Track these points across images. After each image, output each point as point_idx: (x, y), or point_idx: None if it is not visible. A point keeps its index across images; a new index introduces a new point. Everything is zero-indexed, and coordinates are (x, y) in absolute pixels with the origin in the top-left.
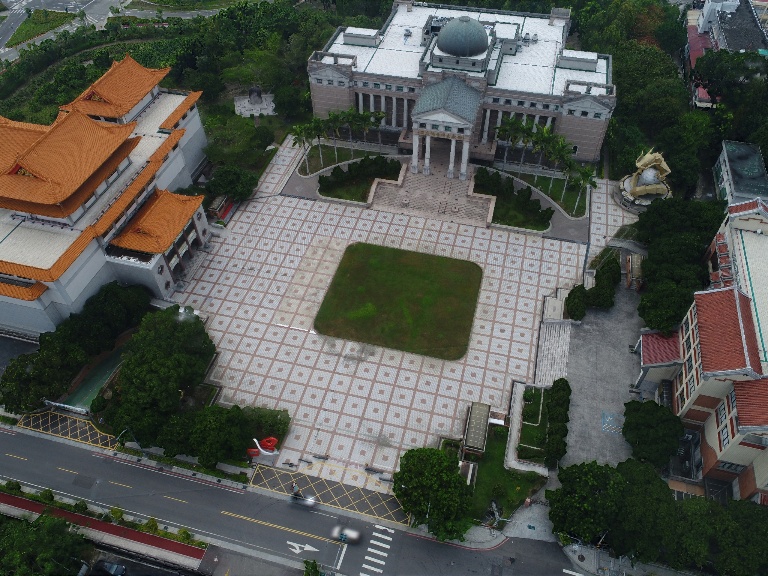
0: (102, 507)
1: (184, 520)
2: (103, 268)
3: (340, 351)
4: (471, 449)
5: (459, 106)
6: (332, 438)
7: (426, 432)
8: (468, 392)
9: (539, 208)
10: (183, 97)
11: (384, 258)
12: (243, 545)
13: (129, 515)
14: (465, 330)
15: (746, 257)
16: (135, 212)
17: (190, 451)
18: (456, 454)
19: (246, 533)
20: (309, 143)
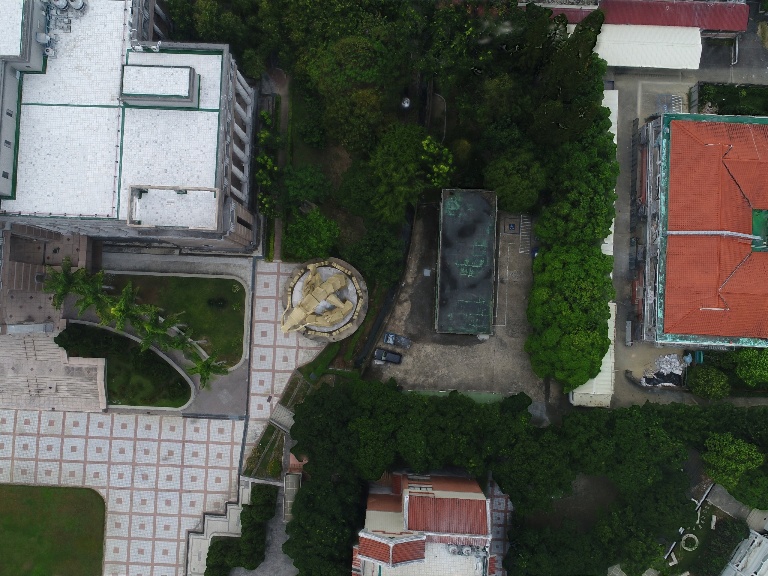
0: None
1: None
2: None
3: None
4: None
5: None
6: None
7: None
8: None
9: (168, 376)
10: None
11: None
12: None
13: None
14: None
15: None
16: None
17: None
18: None
19: None
20: None
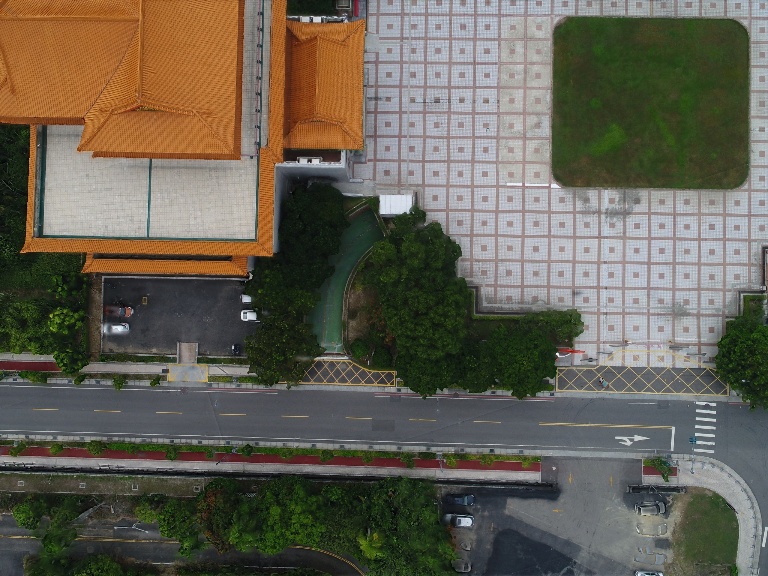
0: (417, 446)
1: (506, 440)
2: (276, 178)
3: (598, 206)
4: None
5: None
6: (624, 320)
7: (723, 289)
8: (760, 228)
9: None
10: None
11: (611, 40)
12: (574, 450)
13: (449, 447)
14: (742, 140)
15: None
16: None
17: (492, 381)
18: None
19: (573, 438)
20: None
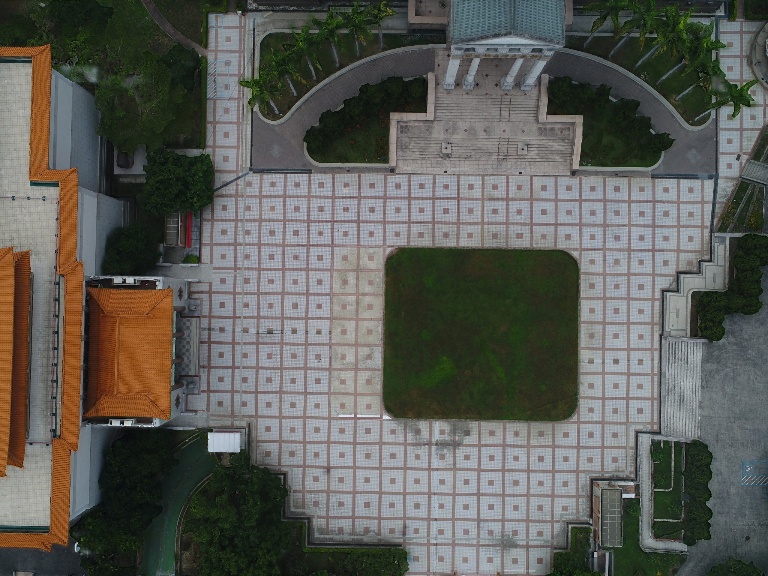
0: None
1: None
2: (92, 435)
3: (428, 438)
4: (608, 546)
5: (535, 8)
6: (453, 551)
7: (551, 521)
8: (588, 460)
9: (648, 130)
10: (22, 69)
11: (442, 272)
12: None
13: None
14: (571, 372)
15: None
16: None
17: None
18: (587, 540)
19: None
20: (276, 97)
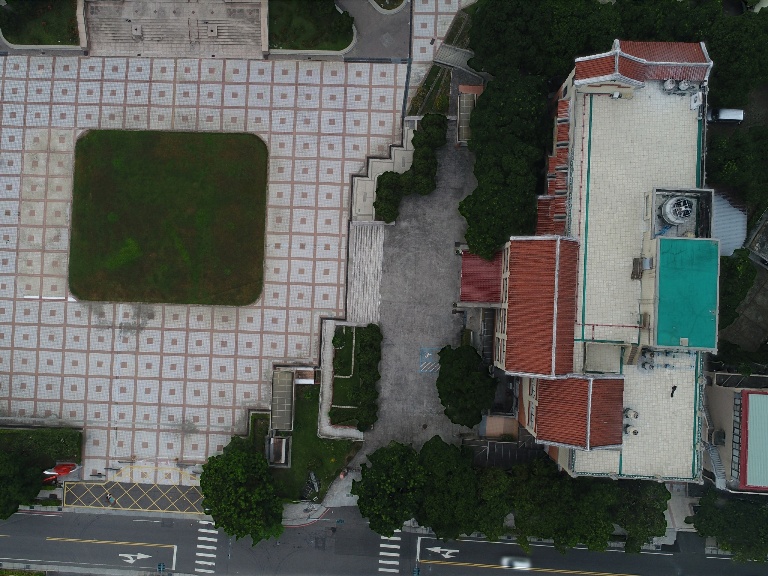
0: None
1: (14, 554)
2: None
3: (112, 321)
4: (279, 429)
5: None
6: (133, 436)
7: (232, 407)
8: (271, 346)
9: (333, 10)
10: None
11: (131, 154)
12: (79, 566)
13: None
14: (256, 256)
15: (590, 152)
16: None
17: None
18: (268, 427)
19: (77, 554)
20: None
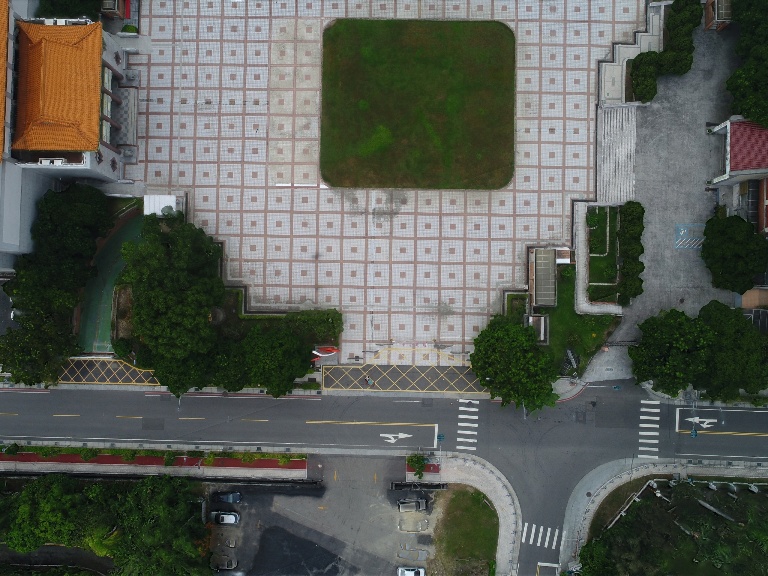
0: (186, 444)
1: (273, 438)
2: (23, 179)
3: (365, 206)
4: None
5: None
6: (390, 319)
7: (487, 288)
8: (524, 228)
9: None
10: None
11: (379, 42)
12: (340, 447)
13: (217, 445)
14: (507, 140)
15: None
16: (13, 76)
17: None
18: (523, 307)
19: (338, 436)
20: None
